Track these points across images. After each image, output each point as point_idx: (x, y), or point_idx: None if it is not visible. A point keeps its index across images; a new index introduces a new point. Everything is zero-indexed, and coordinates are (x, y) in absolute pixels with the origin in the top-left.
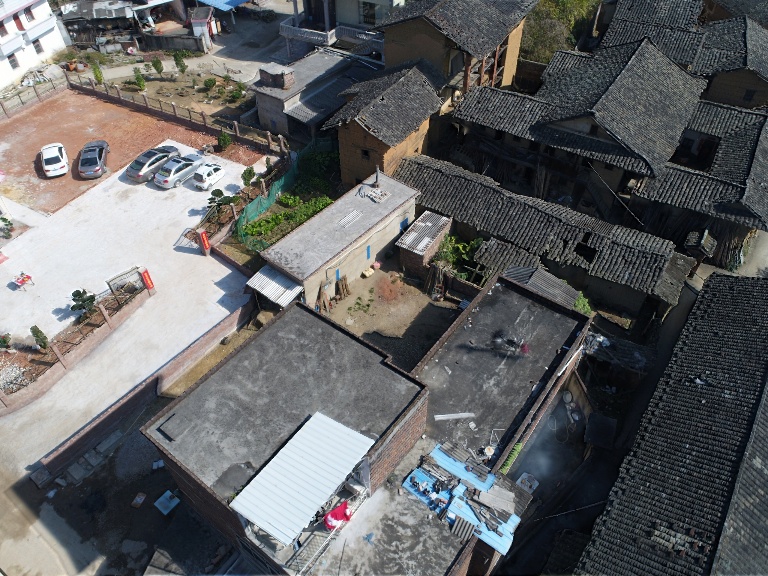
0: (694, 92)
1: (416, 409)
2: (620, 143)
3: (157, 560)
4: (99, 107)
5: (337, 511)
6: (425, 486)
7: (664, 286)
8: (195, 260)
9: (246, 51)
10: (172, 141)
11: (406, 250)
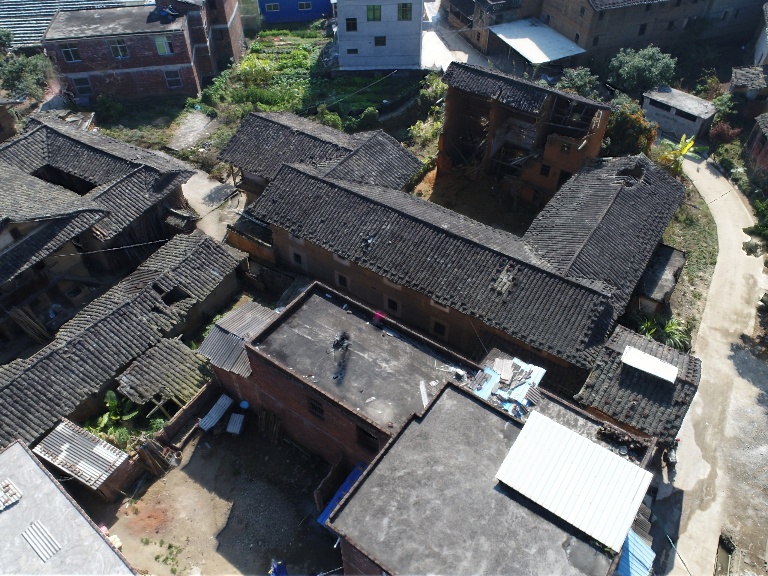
0: None
1: None
2: (54, 218)
3: None
4: None
5: None
6: None
7: None
8: None
9: None
10: None
11: (106, 479)
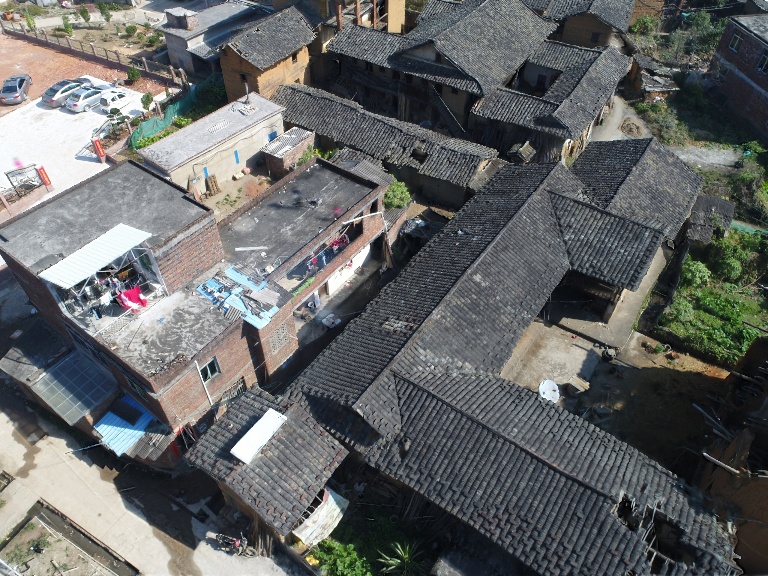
0: (543, 33)
1: (202, 227)
2: (457, 67)
3: (11, 354)
4: (28, 49)
5: (130, 293)
6: (213, 289)
7: (481, 183)
8: (92, 166)
9: (171, 5)
10: (89, 76)
11: (269, 155)
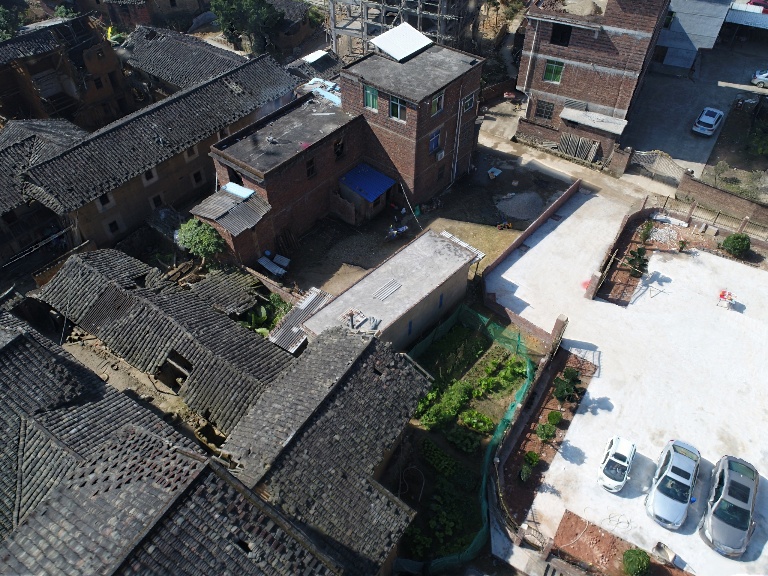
0: None
1: None
2: None
3: (480, 121)
4: None
5: None
6: None
7: None
8: None
9: None
10: None
11: None
